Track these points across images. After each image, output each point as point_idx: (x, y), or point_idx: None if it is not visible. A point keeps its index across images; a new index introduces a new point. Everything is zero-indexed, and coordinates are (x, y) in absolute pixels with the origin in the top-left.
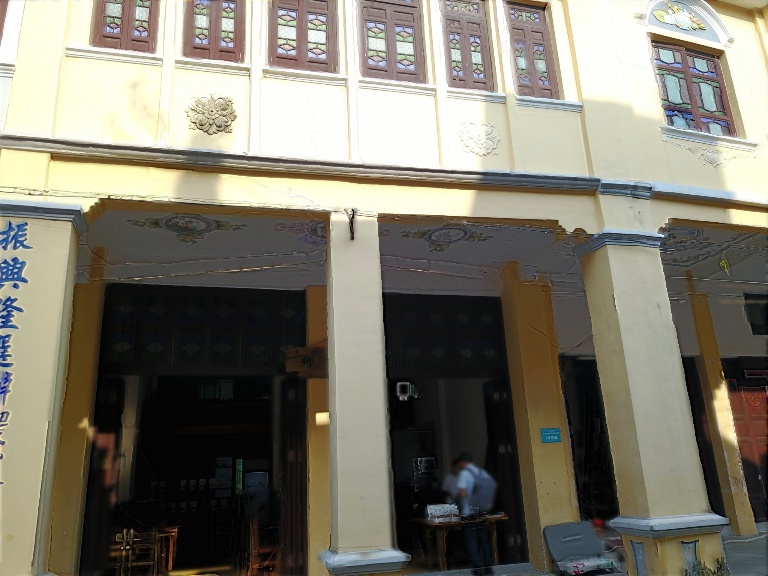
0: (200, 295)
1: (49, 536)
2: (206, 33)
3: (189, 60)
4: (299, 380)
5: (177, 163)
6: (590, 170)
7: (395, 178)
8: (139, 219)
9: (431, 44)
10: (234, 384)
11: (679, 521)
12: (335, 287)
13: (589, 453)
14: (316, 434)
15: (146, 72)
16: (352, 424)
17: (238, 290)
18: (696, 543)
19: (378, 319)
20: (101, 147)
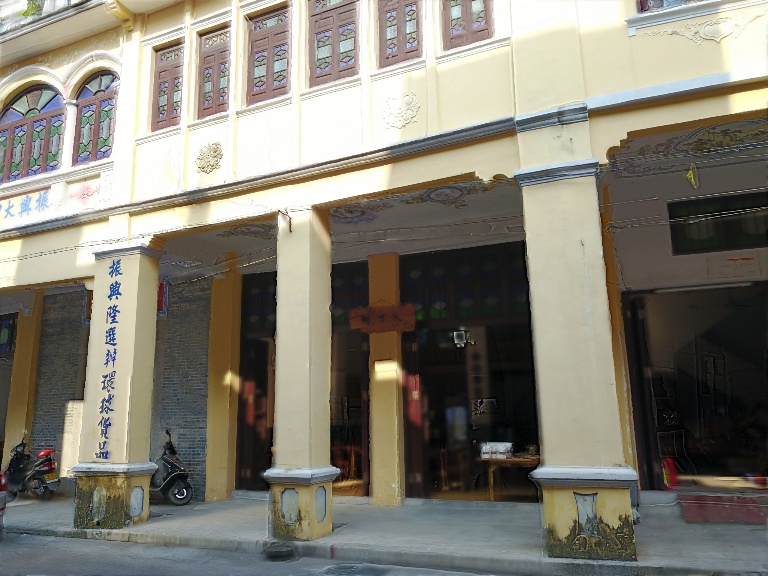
0: None
1: (148, 441)
2: (211, 95)
3: (194, 123)
4: (366, 335)
5: (186, 201)
6: (515, 107)
7: (323, 172)
8: (220, 233)
9: (361, 35)
10: None
11: (568, 471)
12: (279, 272)
13: (703, 397)
14: (375, 379)
15: (175, 140)
16: (285, 376)
17: None
18: (594, 496)
19: (305, 293)
20: (147, 203)
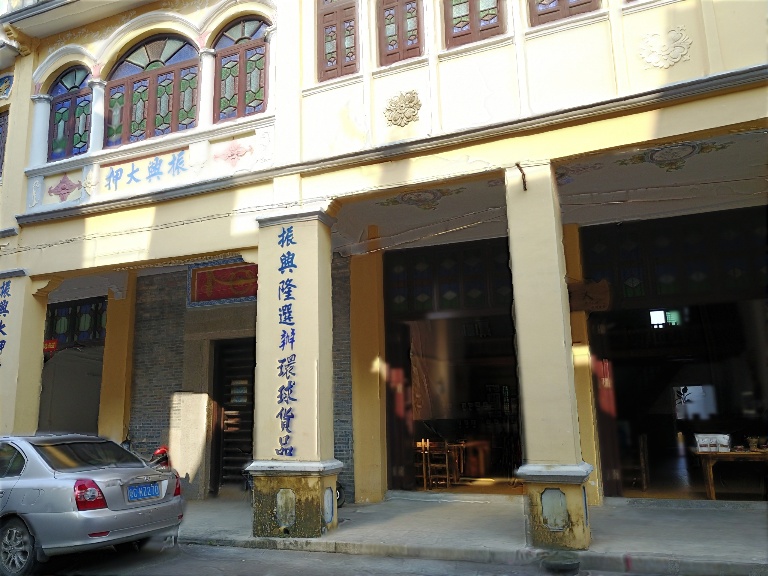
0: (451, 250)
1: (332, 436)
2: (396, 38)
3: (381, 69)
4: None
5: (378, 158)
6: None
7: (565, 120)
8: (382, 201)
9: None
10: (489, 323)
11: None
12: (512, 237)
13: None
14: None
15: (354, 90)
16: (531, 356)
17: (481, 241)
18: None
19: (553, 261)
20: (327, 161)
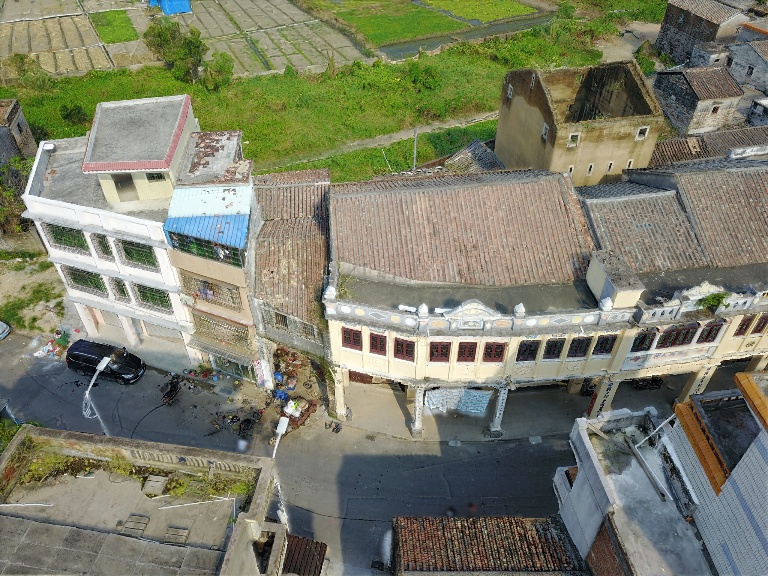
0: None
1: None
2: (756, 327)
3: None
4: None
5: None
6: None
7: None
8: None
9: None
10: None
11: None
12: None
13: None
14: None
15: None
16: None
17: None
18: None
19: None
20: None
